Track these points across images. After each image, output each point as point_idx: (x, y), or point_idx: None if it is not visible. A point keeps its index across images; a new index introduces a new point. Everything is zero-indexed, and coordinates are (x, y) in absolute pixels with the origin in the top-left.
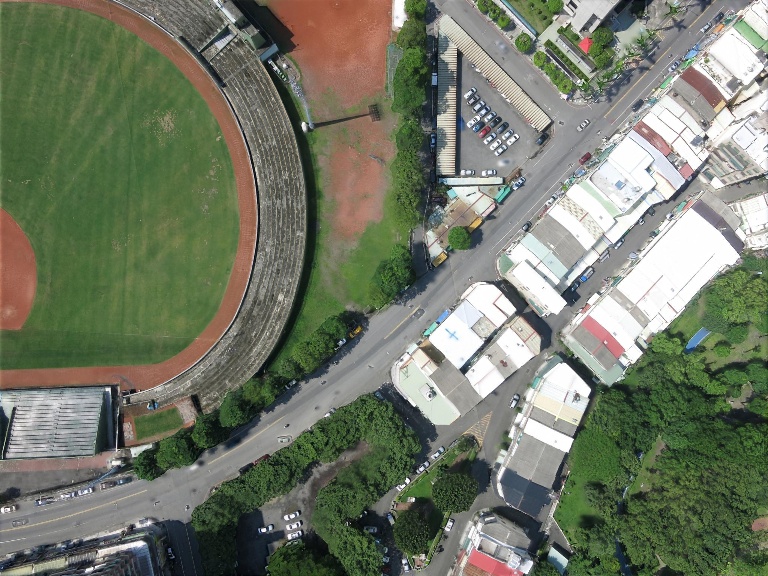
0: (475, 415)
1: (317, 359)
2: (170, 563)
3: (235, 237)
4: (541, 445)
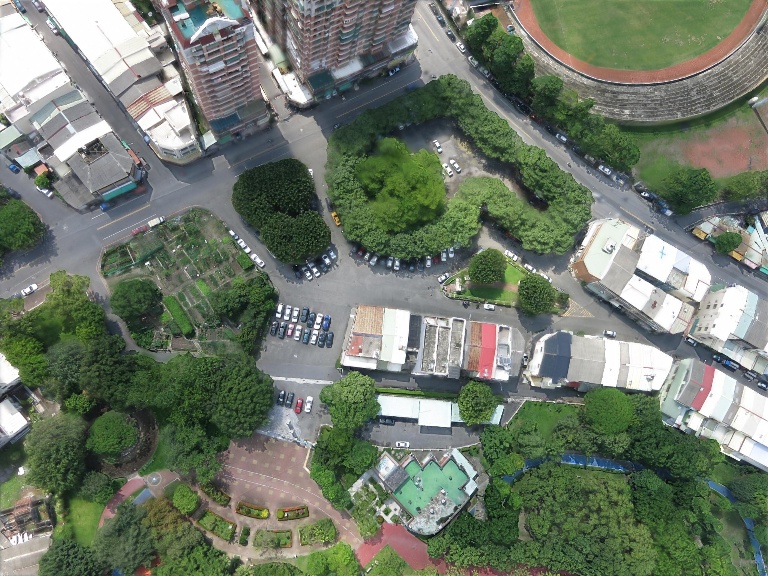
0: (587, 303)
1: (612, 143)
2: (386, 72)
3: (654, 67)
4: (603, 358)
